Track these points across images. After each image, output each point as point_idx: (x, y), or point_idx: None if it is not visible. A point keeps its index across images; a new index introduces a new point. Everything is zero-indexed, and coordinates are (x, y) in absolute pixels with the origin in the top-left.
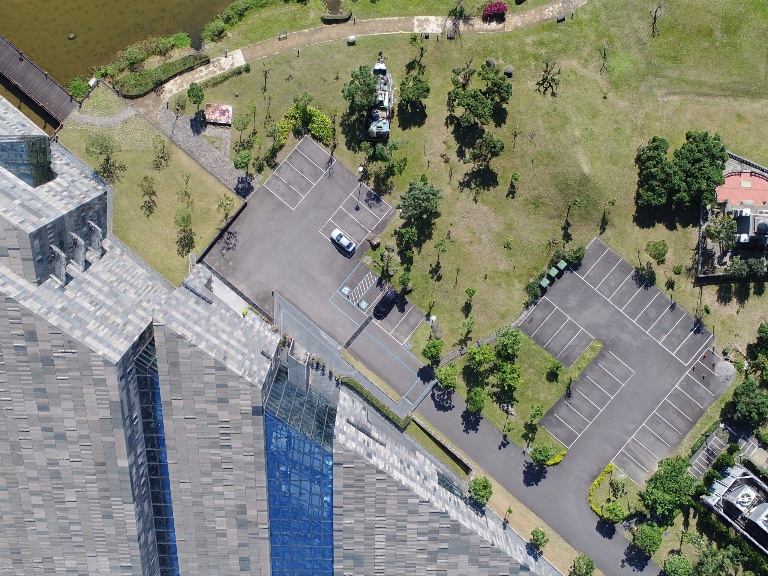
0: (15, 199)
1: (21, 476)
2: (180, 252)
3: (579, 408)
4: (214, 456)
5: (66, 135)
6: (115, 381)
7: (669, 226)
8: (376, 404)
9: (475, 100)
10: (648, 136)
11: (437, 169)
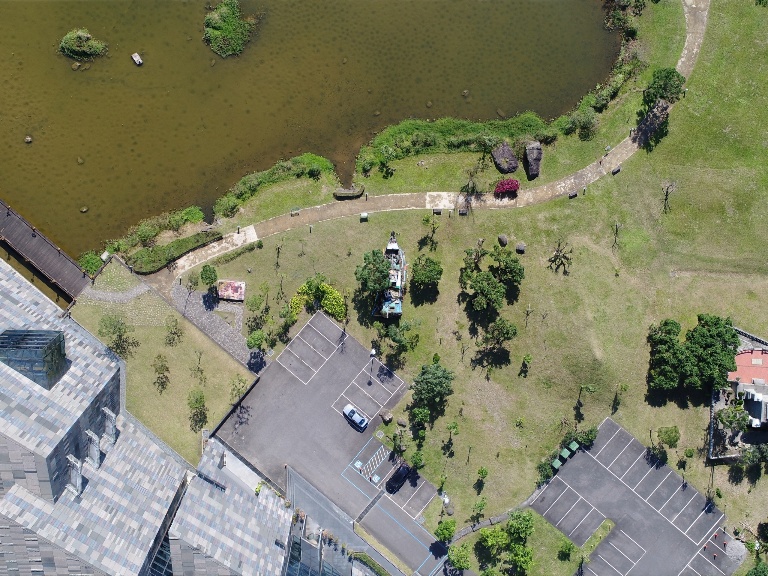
0: (31, 413)
1: None
2: (193, 428)
3: None
4: None
5: (79, 311)
6: None
7: (681, 404)
8: None
9: (488, 284)
10: (660, 313)
11: (449, 346)
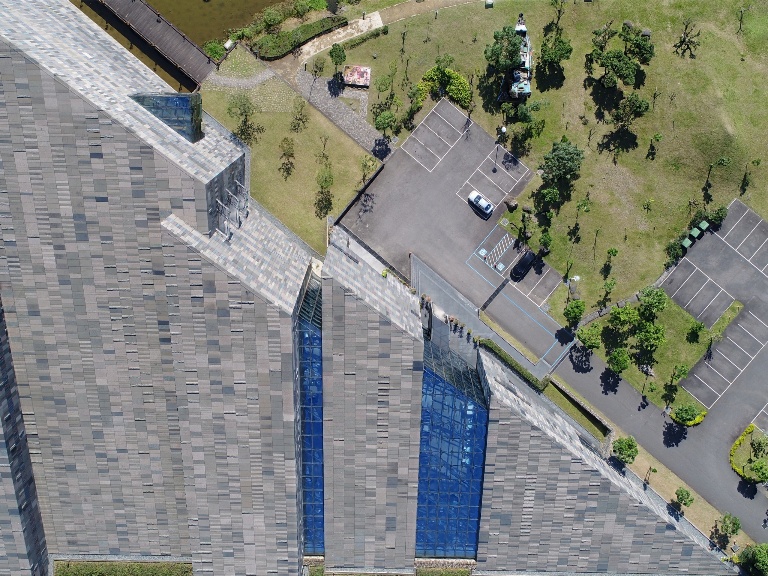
0: (183, 152)
1: (185, 431)
2: (318, 214)
3: (720, 369)
4: (370, 413)
5: (204, 97)
6: (289, 333)
7: None
8: (515, 366)
9: (618, 61)
10: None
11: (576, 131)
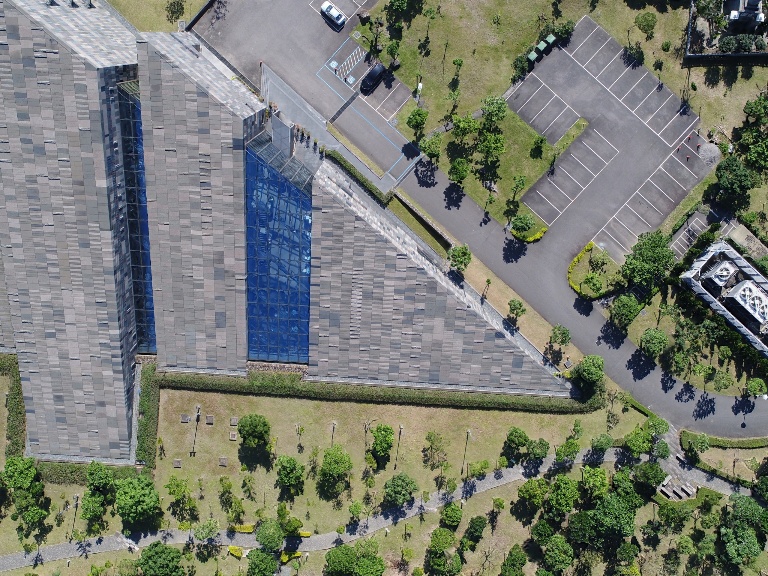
0: None
1: None
2: (169, 18)
3: (562, 185)
4: (193, 195)
5: None
6: (96, 87)
7: (660, 8)
8: (359, 177)
9: None
10: None
11: None
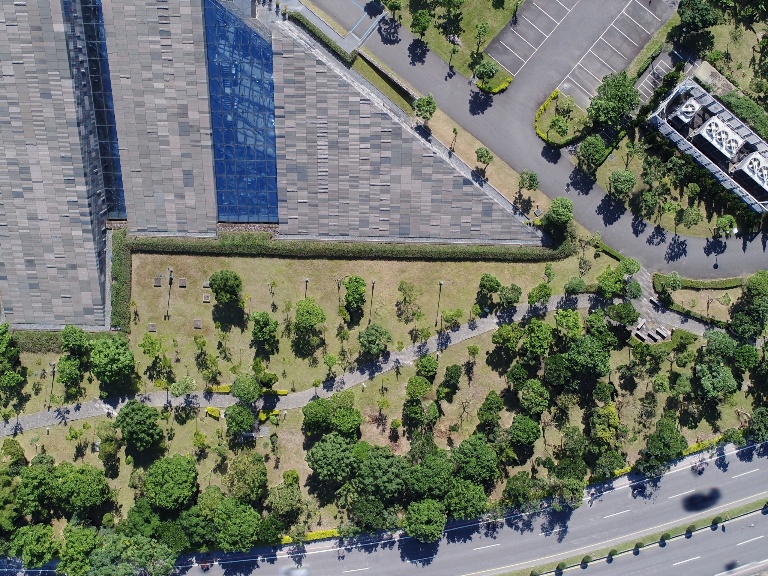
0: None
1: None
2: None
3: (525, 35)
4: (153, 45)
5: None
6: None
7: None
8: (323, 37)
9: None
10: None
11: None
